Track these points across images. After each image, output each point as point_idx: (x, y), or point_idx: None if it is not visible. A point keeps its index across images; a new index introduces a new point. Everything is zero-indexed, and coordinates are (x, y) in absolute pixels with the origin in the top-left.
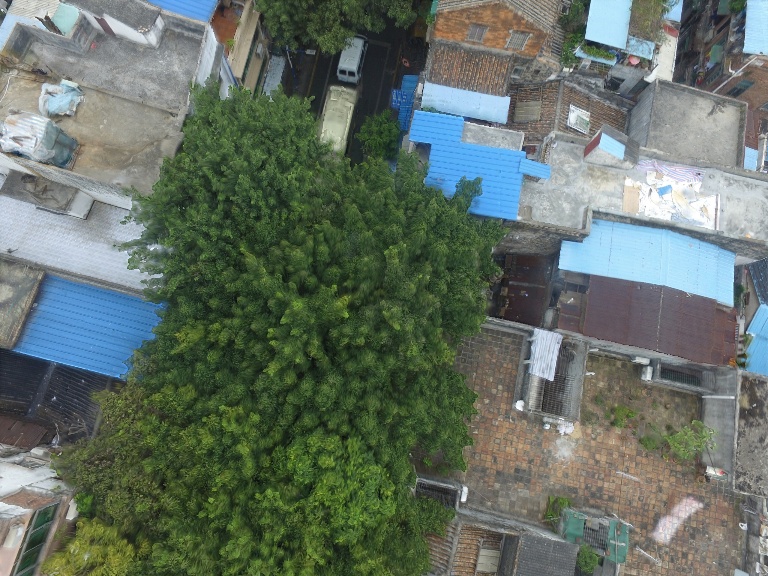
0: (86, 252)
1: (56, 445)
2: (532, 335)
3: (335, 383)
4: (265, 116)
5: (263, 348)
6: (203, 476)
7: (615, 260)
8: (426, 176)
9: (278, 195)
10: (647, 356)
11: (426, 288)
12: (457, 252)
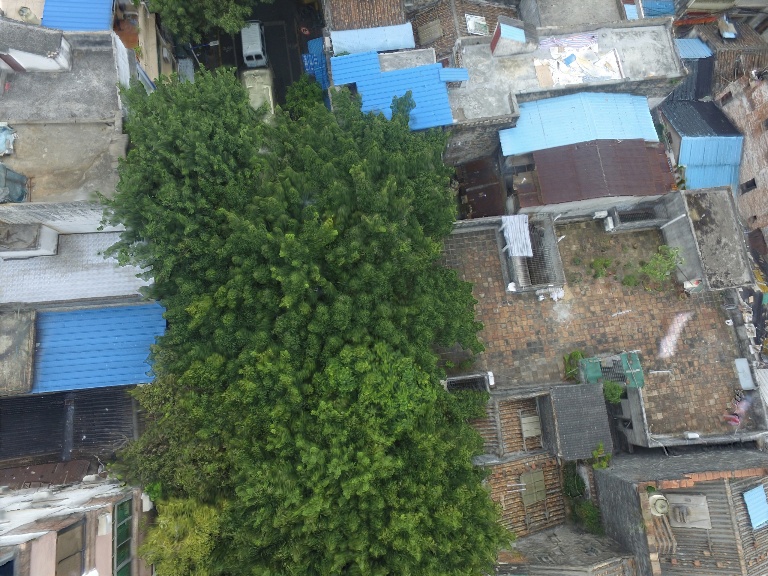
0: (68, 284)
1: (104, 471)
2: (501, 224)
3: (346, 302)
4: (198, 92)
5: (271, 293)
6: (257, 424)
7: (549, 132)
8: (361, 107)
9: (235, 158)
10: (604, 209)
11: (396, 195)
12: (412, 159)
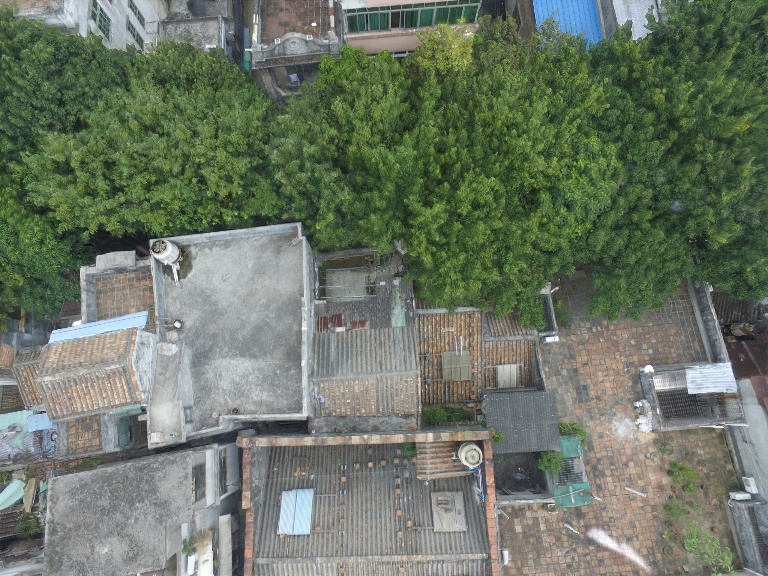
0: None
1: None
2: None
3: (654, 158)
4: None
5: None
6: None
7: None
8: None
9: None
10: (761, 489)
11: None
12: None
